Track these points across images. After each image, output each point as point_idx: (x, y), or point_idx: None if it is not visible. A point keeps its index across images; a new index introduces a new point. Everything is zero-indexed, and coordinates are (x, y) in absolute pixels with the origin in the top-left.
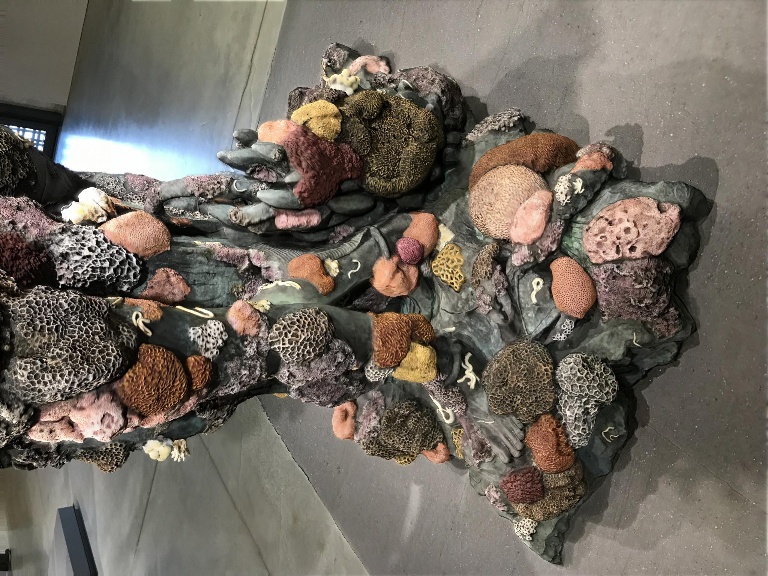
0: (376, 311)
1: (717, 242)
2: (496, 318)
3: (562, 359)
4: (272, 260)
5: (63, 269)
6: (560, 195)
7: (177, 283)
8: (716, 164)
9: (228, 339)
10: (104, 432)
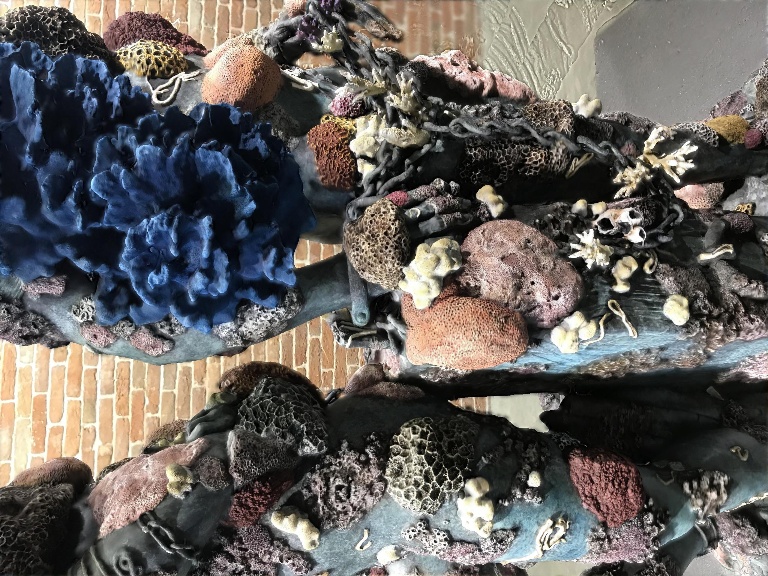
0: None
1: None
2: None
3: None
4: None
5: None
6: None
7: None
8: None
9: None
10: None
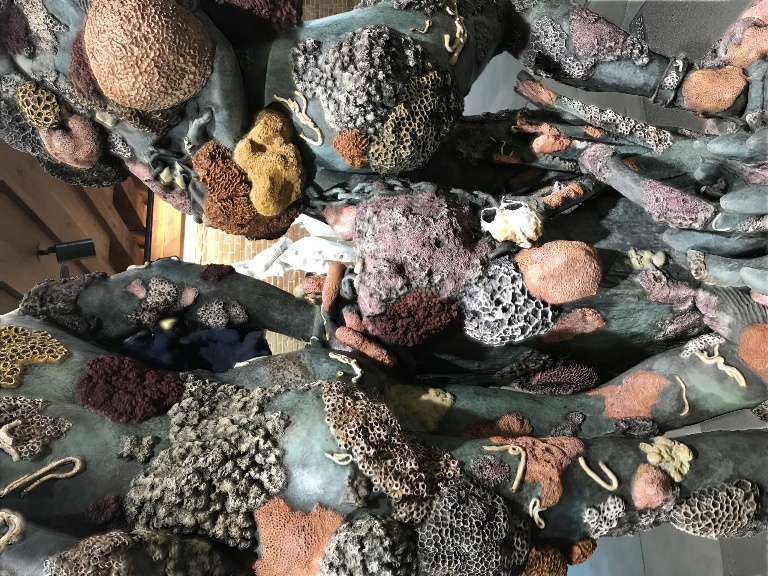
0: None
1: None
2: None
3: None
4: (724, 312)
5: (472, 326)
6: None
7: (592, 321)
8: None
9: None
10: None
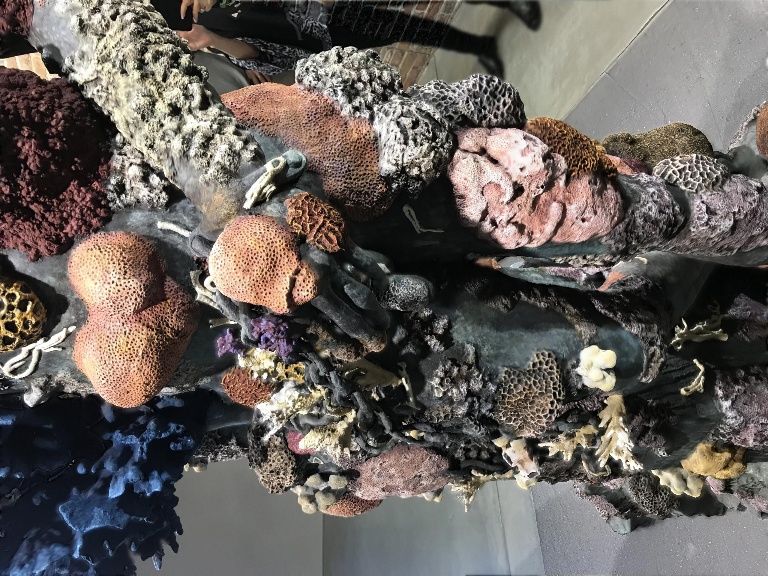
0: (763, 323)
1: None
2: None
3: None
4: None
5: None
6: None
7: None
8: None
9: None
10: (532, 151)
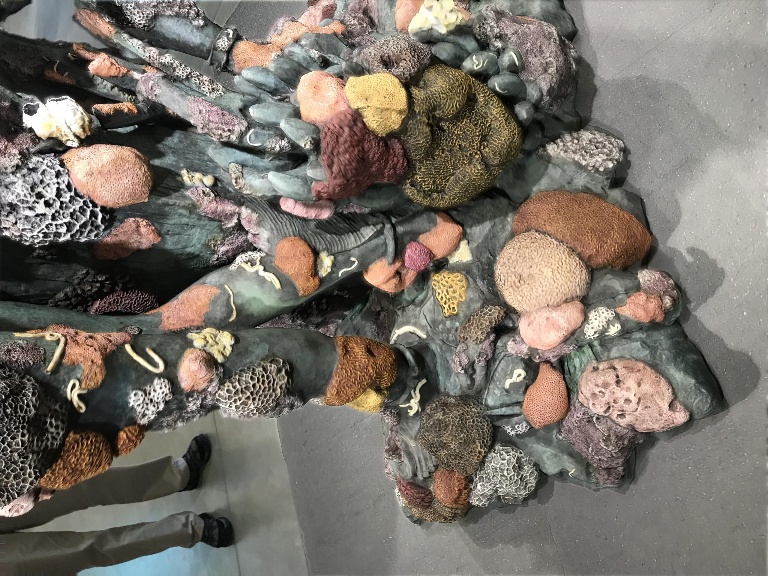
0: None
1: (703, 440)
2: (463, 381)
3: (500, 446)
4: (264, 228)
5: (9, 222)
6: (590, 329)
7: (147, 234)
8: (759, 380)
9: (172, 397)
10: None
